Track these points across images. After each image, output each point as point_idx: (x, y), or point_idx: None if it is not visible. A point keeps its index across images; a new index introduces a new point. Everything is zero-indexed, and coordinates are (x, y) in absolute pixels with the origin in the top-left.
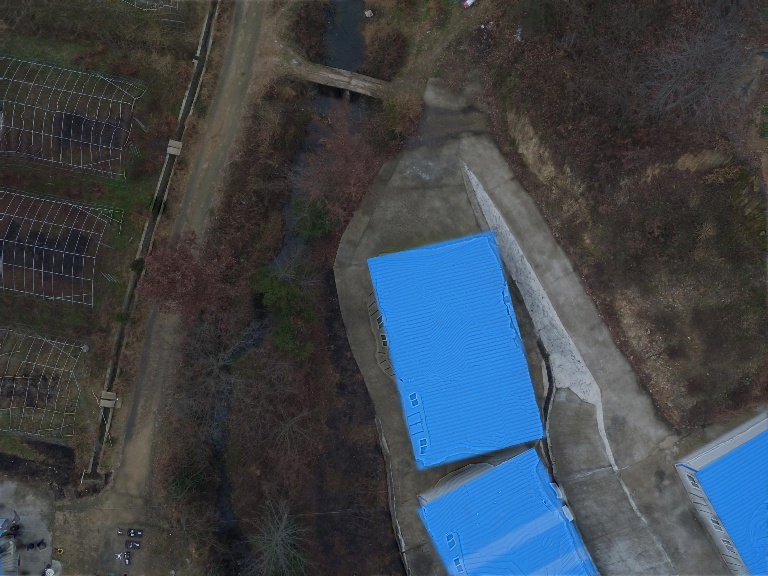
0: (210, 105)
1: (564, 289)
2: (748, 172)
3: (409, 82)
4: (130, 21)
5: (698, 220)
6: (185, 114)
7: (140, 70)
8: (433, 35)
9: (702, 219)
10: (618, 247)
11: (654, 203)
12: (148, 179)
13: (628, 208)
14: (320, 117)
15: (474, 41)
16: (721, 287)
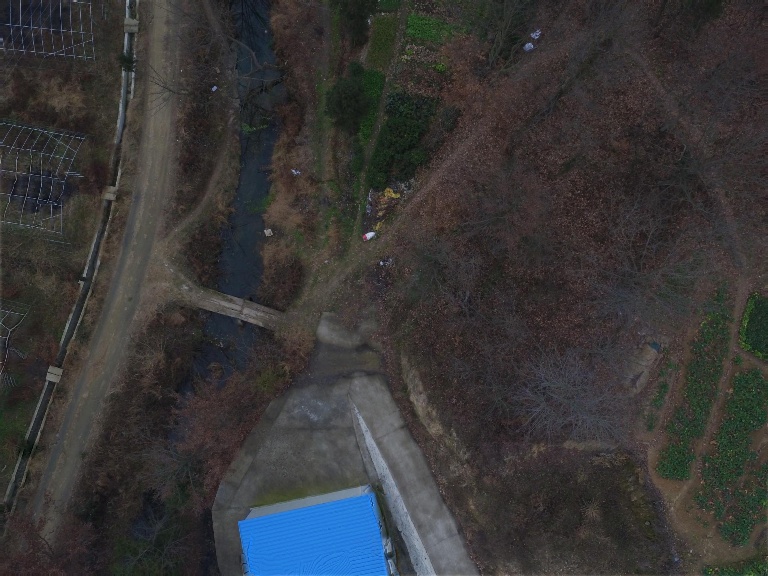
0: (94, 330)
1: (447, 552)
2: (634, 463)
3: (303, 315)
4: (14, 240)
5: (586, 495)
6: (68, 338)
7: (23, 289)
8: (330, 266)
9: (590, 494)
10: (502, 519)
11: (541, 475)
12: (25, 406)
13: (514, 479)
14: (212, 340)
15: (371, 277)
16: (606, 567)
